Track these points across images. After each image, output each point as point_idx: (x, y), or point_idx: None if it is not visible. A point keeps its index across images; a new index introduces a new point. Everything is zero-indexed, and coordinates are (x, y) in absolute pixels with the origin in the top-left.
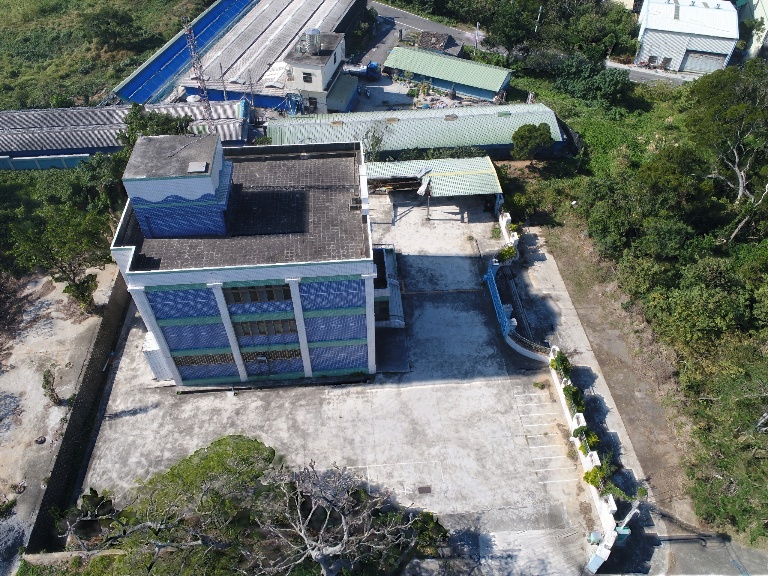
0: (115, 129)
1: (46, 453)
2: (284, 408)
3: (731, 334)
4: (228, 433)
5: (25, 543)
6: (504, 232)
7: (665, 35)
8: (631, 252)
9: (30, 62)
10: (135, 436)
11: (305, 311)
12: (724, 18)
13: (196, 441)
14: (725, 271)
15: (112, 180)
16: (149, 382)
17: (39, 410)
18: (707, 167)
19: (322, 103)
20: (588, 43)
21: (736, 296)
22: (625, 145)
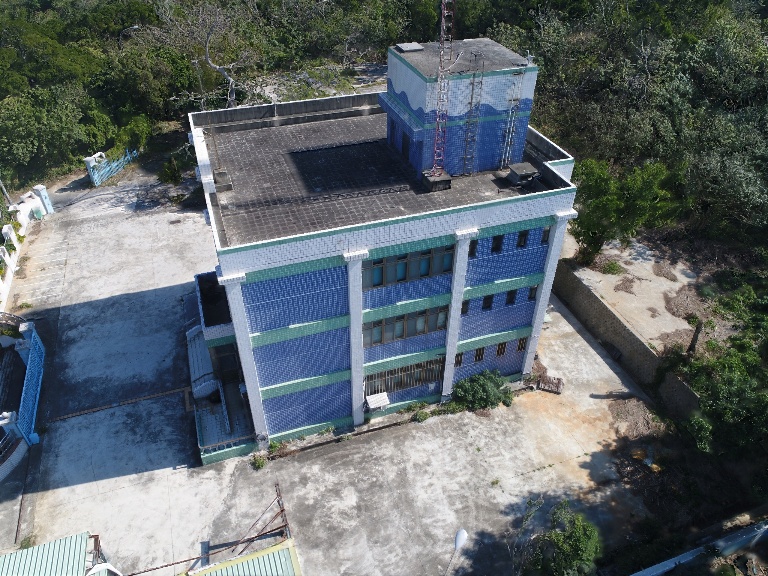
0: None
1: None
2: None
3: None
4: None
5: None
6: None
7: None
8: None
9: None
10: None
11: None
12: None
13: None
14: None
15: None
16: None
17: None
18: None
19: None
20: None
21: None
22: None
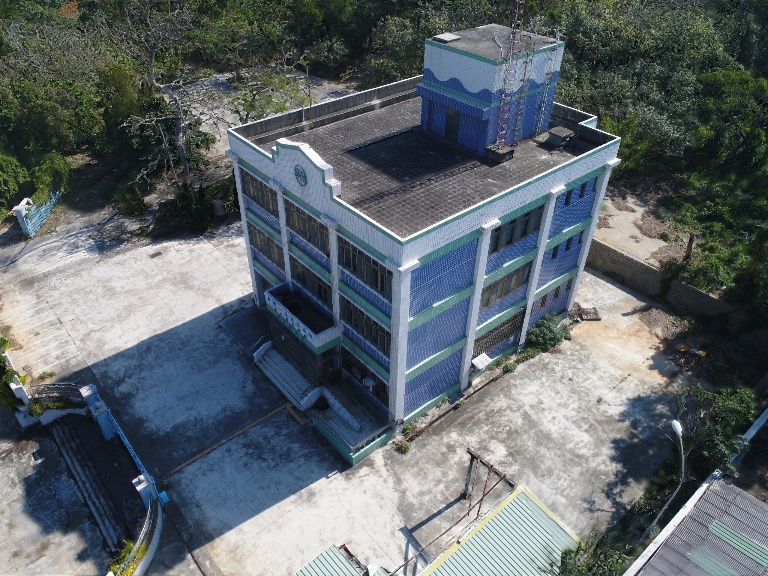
0: None
1: None
2: None
3: None
4: None
5: None
6: None
7: None
8: None
9: None
10: None
11: None
12: None
13: None
14: None
15: None
16: None
17: None
18: None
19: None
20: None
21: None
22: None
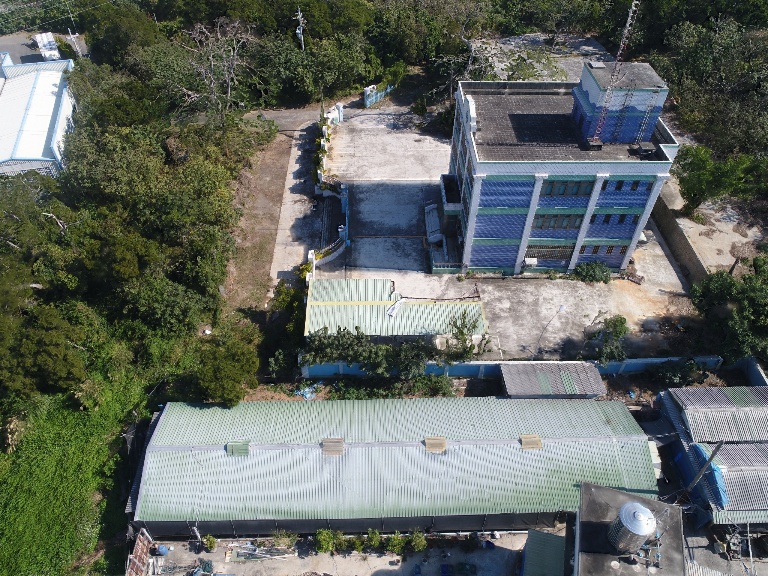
0: None
1: None
2: None
3: None
4: None
5: None
6: None
7: None
8: None
9: None
10: None
11: None
12: None
13: None
14: None
15: None
16: None
17: None
18: None
19: None
20: None
21: None
22: None
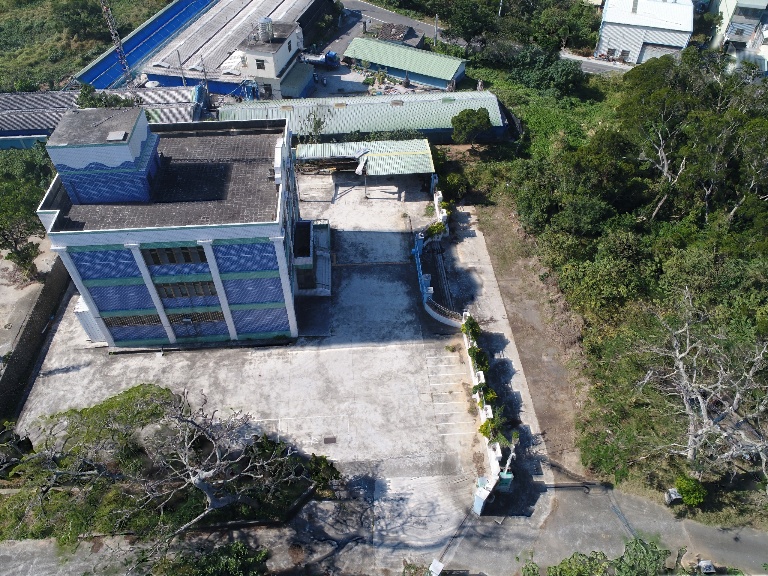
0: None
1: None
2: (208, 367)
3: (634, 302)
4: None
5: None
6: (437, 210)
7: (622, 28)
8: (551, 227)
9: (2, 50)
10: (65, 391)
11: (222, 273)
12: (680, 12)
13: None
14: (634, 244)
15: None
16: (84, 343)
17: None
18: (637, 150)
19: (276, 89)
20: (543, 35)
21: (643, 267)
22: (566, 131)
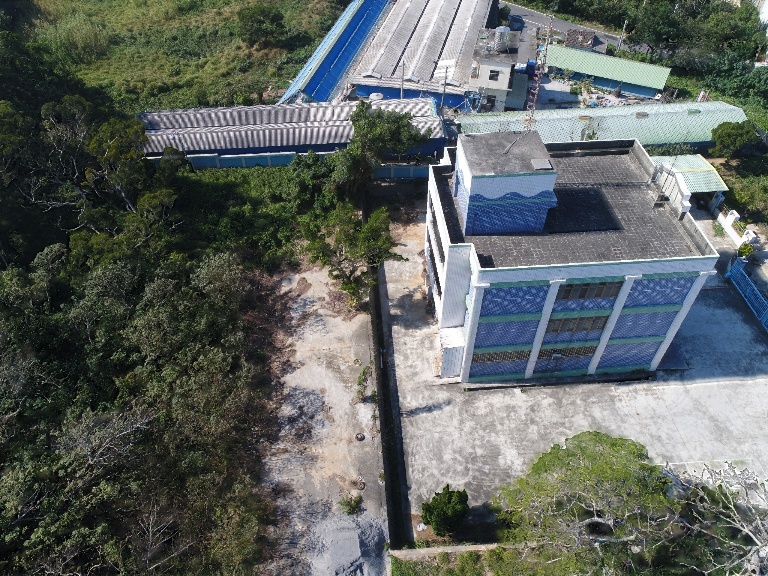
0: (318, 127)
1: (370, 449)
2: (577, 405)
3: None
4: (532, 430)
5: (387, 539)
6: (729, 230)
7: None
8: None
9: (186, 60)
10: (440, 433)
11: (624, 308)
12: None
13: (503, 438)
14: None
15: (347, 178)
16: (432, 379)
17: (346, 407)
18: None
19: (501, 101)
20: (739, 41)
21: None
22: None
